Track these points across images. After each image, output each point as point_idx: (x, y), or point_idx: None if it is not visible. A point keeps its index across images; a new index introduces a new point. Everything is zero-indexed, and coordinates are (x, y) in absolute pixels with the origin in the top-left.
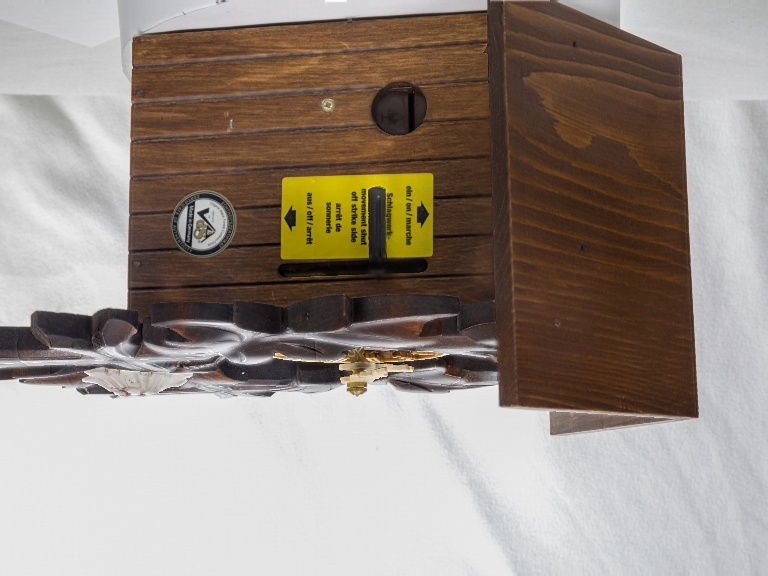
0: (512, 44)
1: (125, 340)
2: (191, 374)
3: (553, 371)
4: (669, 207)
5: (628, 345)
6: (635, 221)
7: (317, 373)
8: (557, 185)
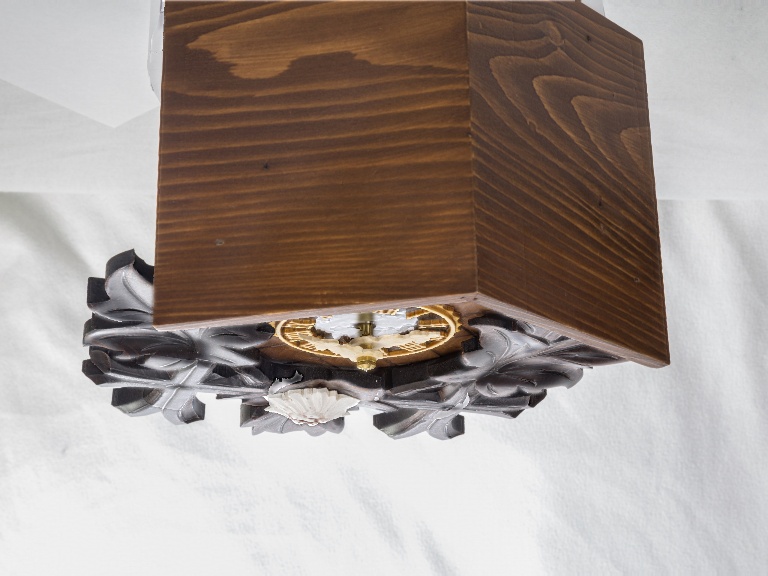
0: (174, 22)
1: (111, 365)
2: (317, 391)
3: (209, 287)
4: (429, 88)
5: (339, 241)
6: (362, 119)
7: (442, 365)
8: (230, 121)
